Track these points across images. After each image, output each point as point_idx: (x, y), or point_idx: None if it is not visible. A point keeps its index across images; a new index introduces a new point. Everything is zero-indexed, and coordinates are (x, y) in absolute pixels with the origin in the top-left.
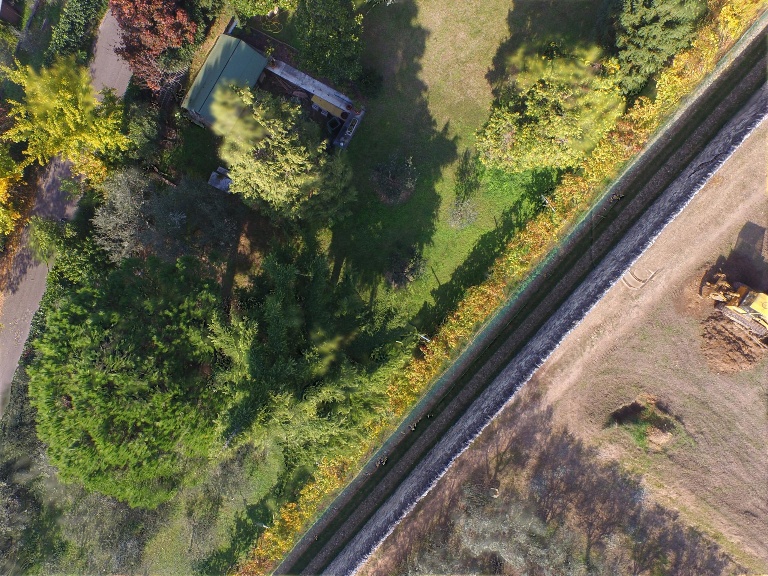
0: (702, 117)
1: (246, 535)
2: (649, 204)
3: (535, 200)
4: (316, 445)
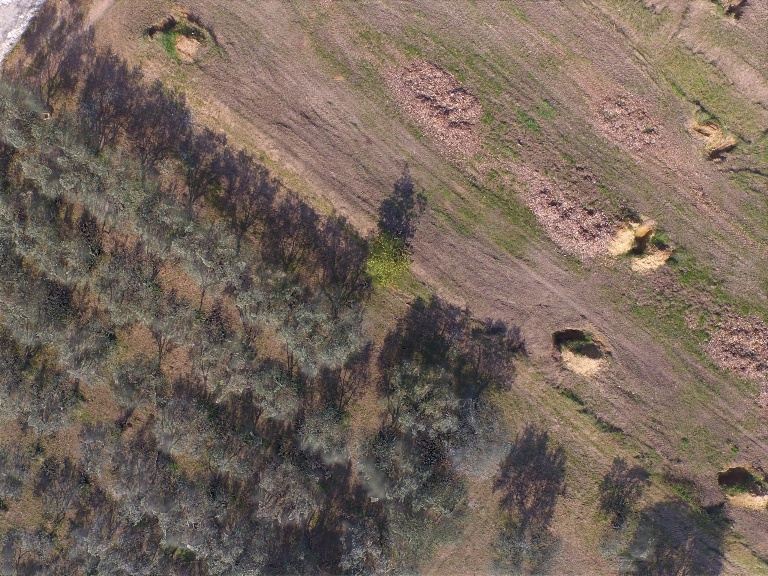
0: None
1: None
2: None
3: None
4: None
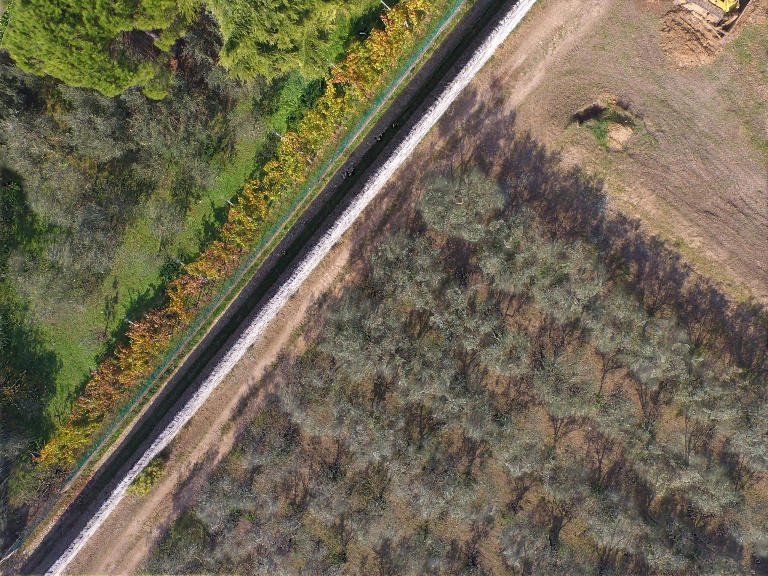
0: None
1: (214, 239)
2: None
3: None
4: (267, 9)
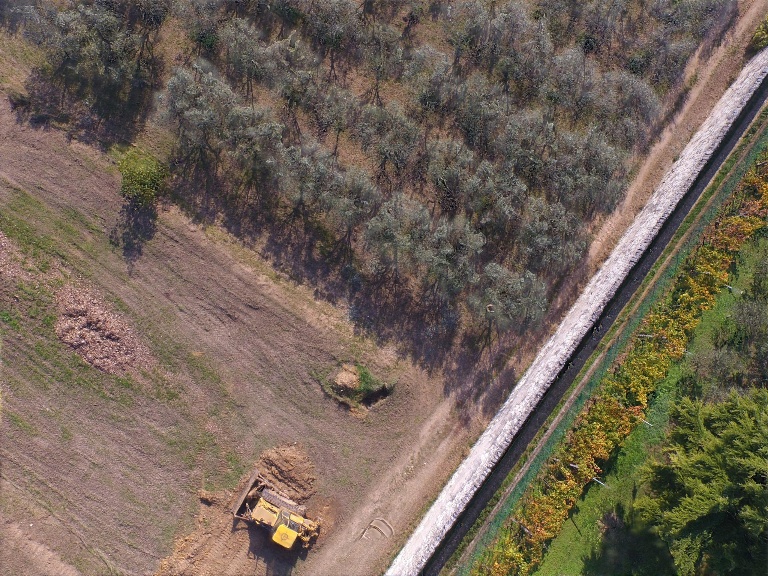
0: None
1: None
2: None
3: None
4: None
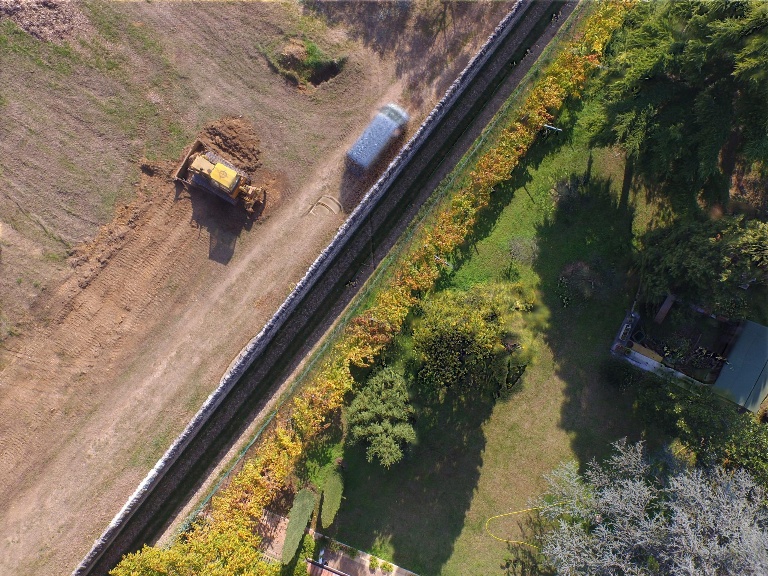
0: (280, 363)
1: None
2: (322, 278)
3: (441, 272)
4: None
